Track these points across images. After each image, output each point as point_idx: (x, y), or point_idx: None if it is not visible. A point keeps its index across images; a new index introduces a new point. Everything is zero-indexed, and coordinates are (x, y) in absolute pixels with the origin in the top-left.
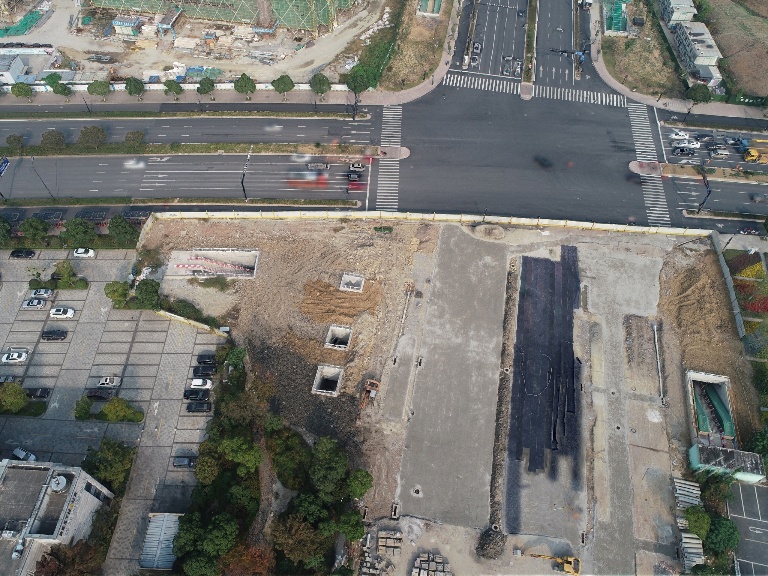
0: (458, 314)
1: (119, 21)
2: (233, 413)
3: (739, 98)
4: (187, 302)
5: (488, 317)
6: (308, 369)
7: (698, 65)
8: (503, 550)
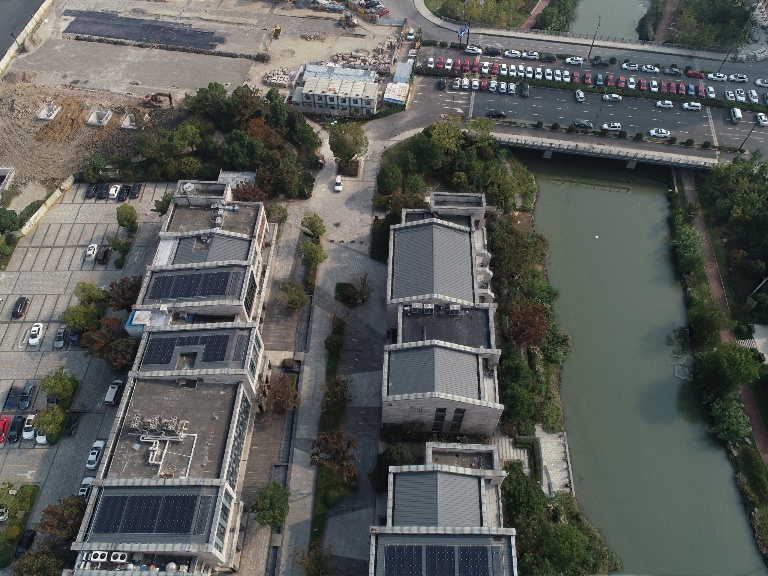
0: (101, 64)
1: None
2: (152, 141)
3: None
4: (23, 210)
5: (110, 51)
6: (122, 132)
7: None
8: (266, 54)
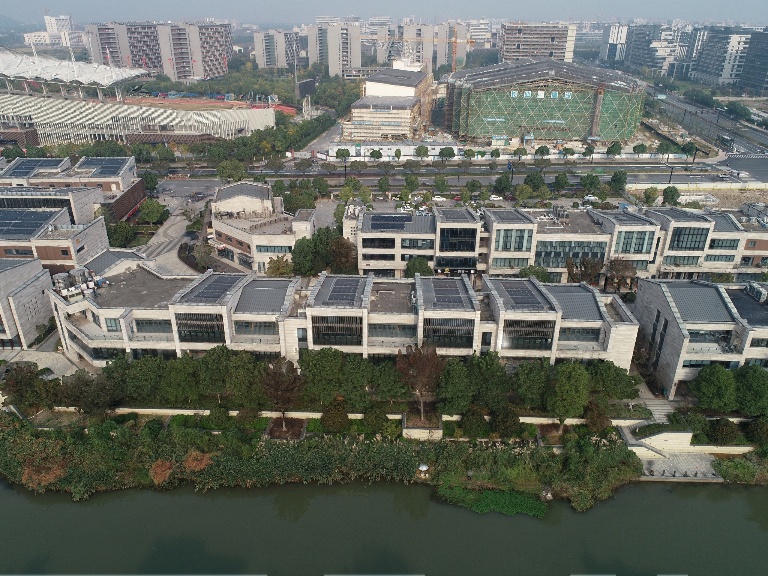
0: None
1: None
2: None
3: None
4: None
5: None
6: None
7: None
8: None
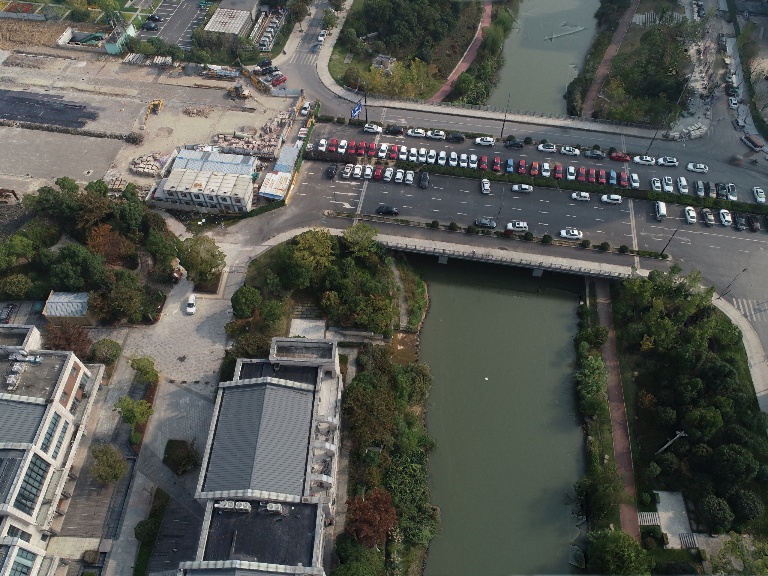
0: None
1: None
2: None
3: None
4: None
5: None
6: None
7: None
8: (140, 134)
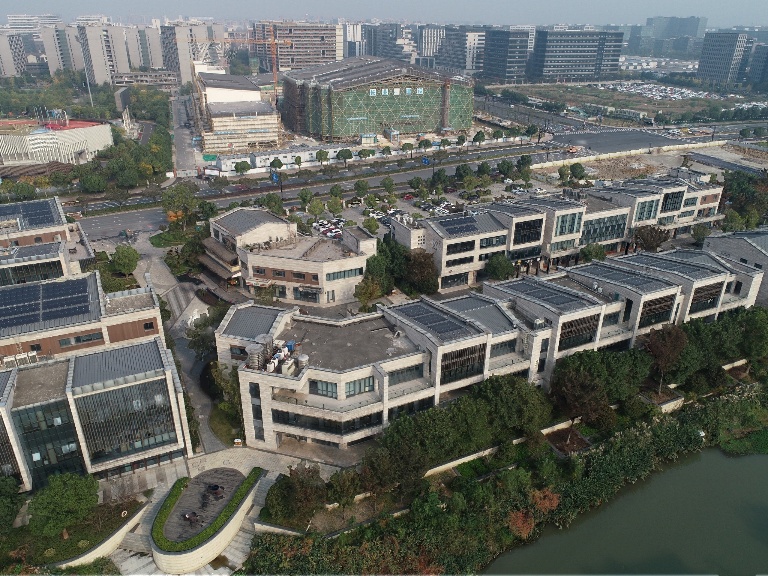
0: None
1: (367, 135)
2: None
3: (671, 122)
4: None
5: None
6: None
7: (641, 118)
8: None
